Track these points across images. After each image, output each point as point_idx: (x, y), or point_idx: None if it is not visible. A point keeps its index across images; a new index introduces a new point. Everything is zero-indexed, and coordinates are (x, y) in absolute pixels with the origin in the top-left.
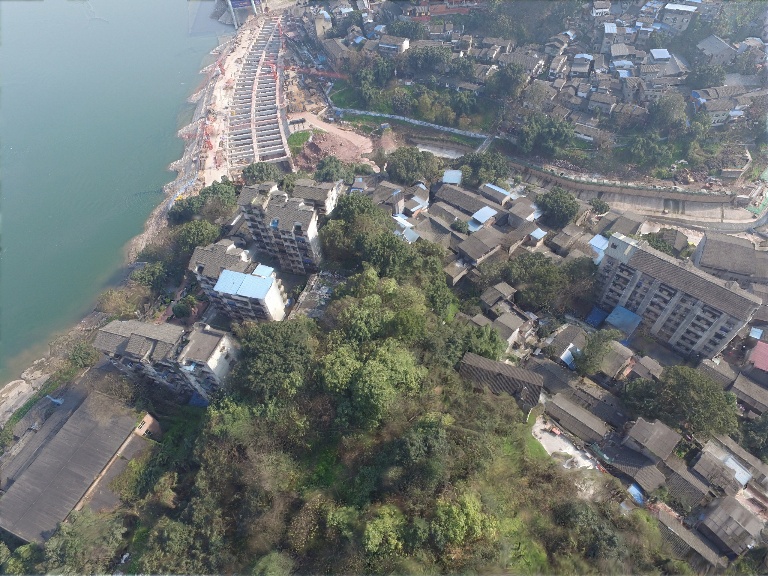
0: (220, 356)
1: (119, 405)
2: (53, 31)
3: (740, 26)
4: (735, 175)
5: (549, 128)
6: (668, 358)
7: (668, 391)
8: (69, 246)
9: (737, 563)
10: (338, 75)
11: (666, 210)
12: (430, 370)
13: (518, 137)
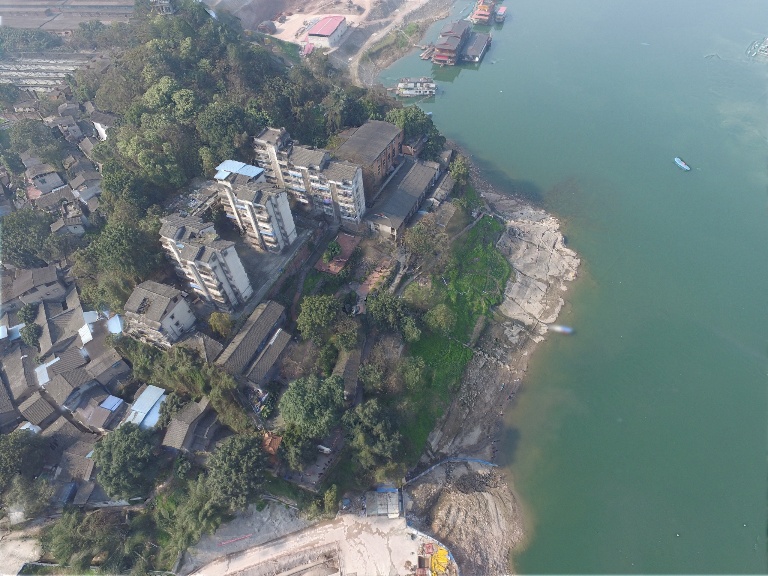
0: None
1: (346, 159)
2: None
3: None
4: None
5: None
6: None
7: None
8: (634, 537)
9: (81, 103)
10: None
11: None
12: None
13: None
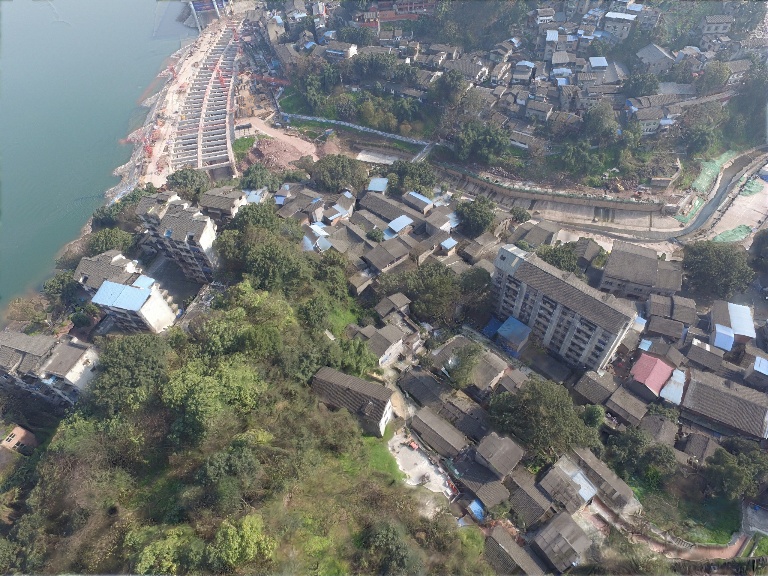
0: (84, 369)
1: None
2: (19, 33)
3: (680, 35)
4: (664, 184)
5: (485, 135)
6: (556, 370)
7: (524, 406)
8: (3, 251)
9: None
10: (289, 80)
11: (596, 218)
12: (273, 385)
13: (455, 144)
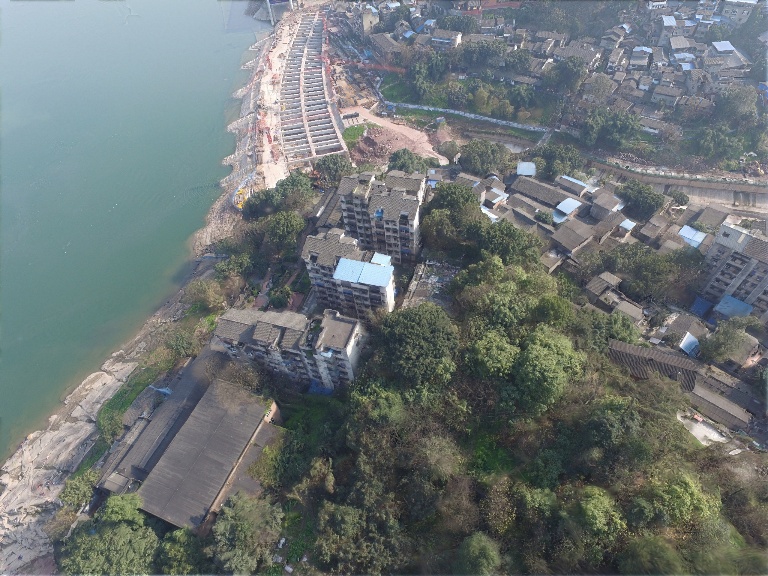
0: (353, 343)
1: (245, 393)
2: (87, 28)
3: None
4: None
5: (613, 121)
6: None
7: None
8: (132, 240)
9: None
10: (387, 70)
11: (736, 202)
12: None
13: (581, 130)
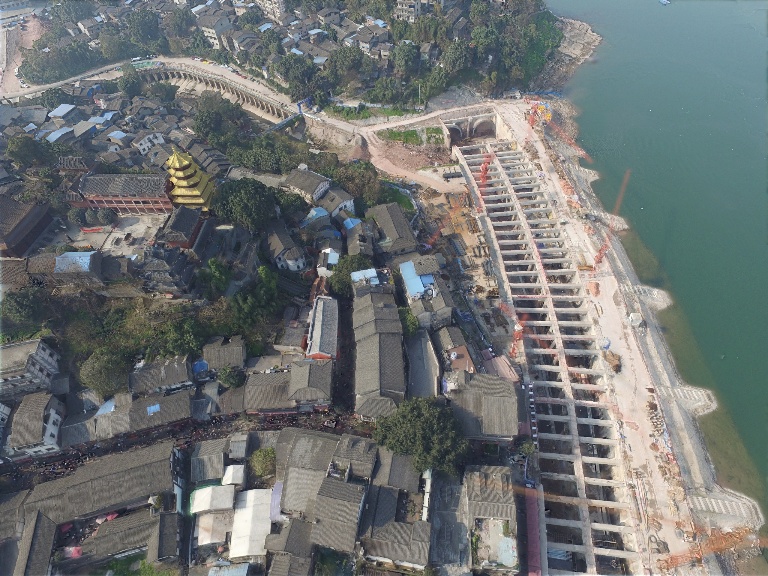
0: None
1: None
2: None
3: None
4: None
5: None
6: None
7: None
8: (630, 112)
9: None
10: None
11: None
12: None
13: None
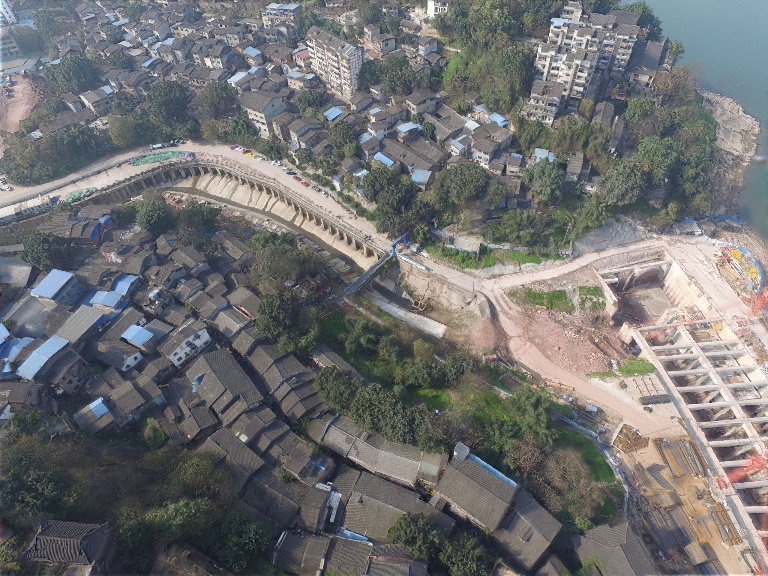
0: None
1: None
2: None
3: None
4: None
5: None
6: None
7: None
8: None
9: None
10: None
11: None
12: None
13: (317, 260)
